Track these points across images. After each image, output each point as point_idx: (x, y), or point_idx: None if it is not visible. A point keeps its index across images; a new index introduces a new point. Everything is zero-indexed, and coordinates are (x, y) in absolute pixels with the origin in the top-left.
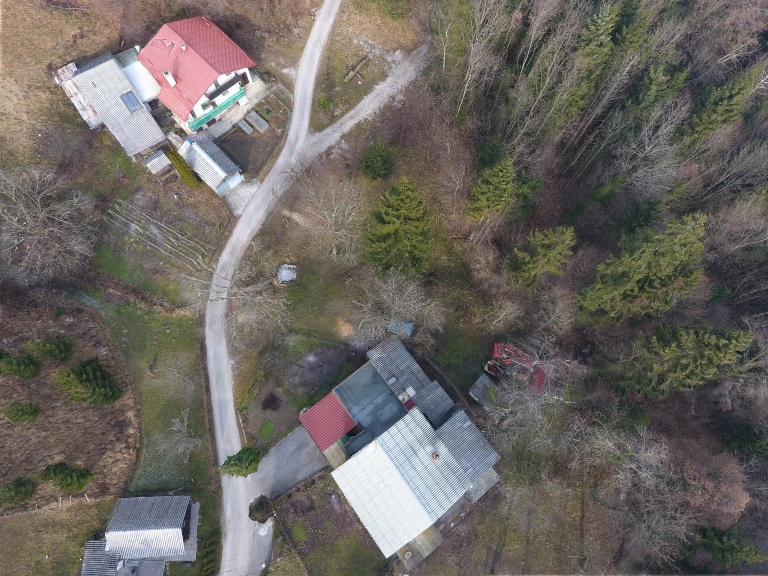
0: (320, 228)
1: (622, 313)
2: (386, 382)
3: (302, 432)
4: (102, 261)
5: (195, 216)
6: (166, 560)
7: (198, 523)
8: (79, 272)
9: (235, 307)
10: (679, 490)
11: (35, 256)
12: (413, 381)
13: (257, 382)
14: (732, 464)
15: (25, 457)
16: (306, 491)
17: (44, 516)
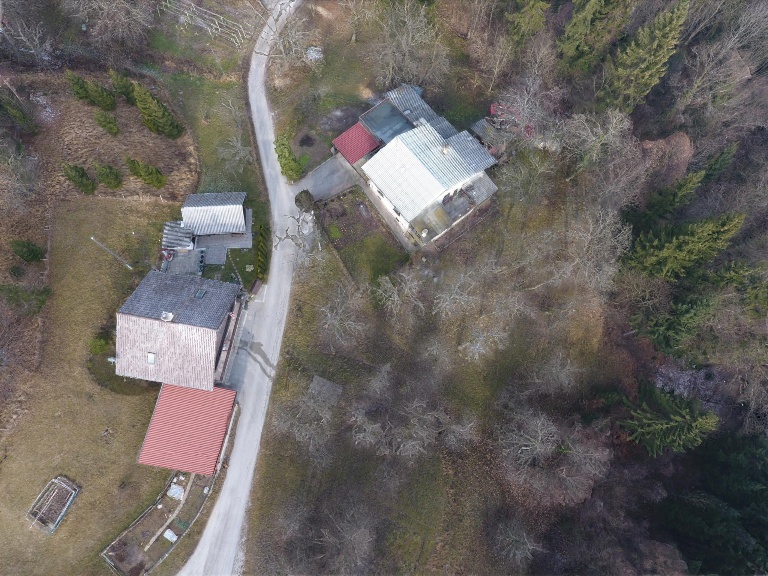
0: (343, 5)
1: (594, 47)
2: (402, 113)
3: (333, 162)
4: (157, 44)
5: (234, 11)
6: (227, 248)
7: (252, 223)
8: (140, 46)
9: (273, 73)
10: (639, 154)
11: (106, 23)
12: (424, 115)
13: (294, 127)
14: (680, 132)
15: (111, 160)
16: (339, 201)
17: (129, 205)
